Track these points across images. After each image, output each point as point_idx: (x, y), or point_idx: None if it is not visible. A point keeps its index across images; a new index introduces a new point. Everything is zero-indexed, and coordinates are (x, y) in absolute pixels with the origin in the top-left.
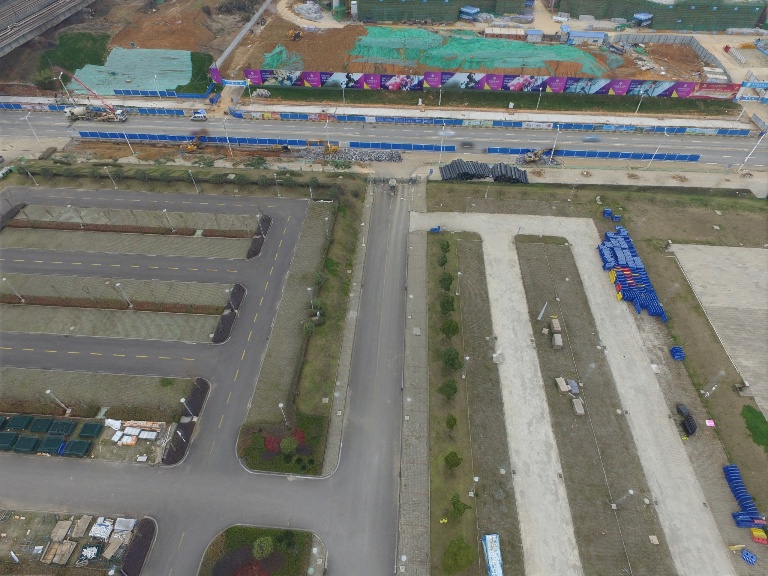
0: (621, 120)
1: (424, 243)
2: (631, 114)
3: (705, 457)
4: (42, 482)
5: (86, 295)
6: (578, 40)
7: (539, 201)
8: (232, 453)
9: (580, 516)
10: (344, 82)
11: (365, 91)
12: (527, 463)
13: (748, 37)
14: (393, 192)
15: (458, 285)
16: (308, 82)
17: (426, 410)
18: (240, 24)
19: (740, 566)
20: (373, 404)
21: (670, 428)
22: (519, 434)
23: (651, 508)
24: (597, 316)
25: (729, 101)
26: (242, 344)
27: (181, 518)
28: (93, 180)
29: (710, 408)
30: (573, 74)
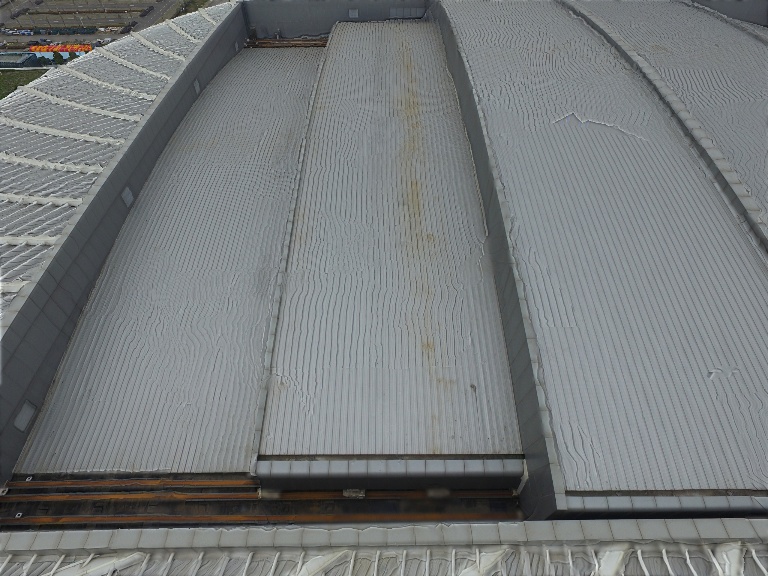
0: None
1: None
2: None
3: None
4: None
5: None
6: None
7: None
8: None
9: None
10: None
11: None
12: None
13: None
14: None
15: None
16: None
17: None
18: None
19: None
20: None
21: None
22: None
23: None
24: None
25: None
26: None
27: None
28: None
29: None
30: None
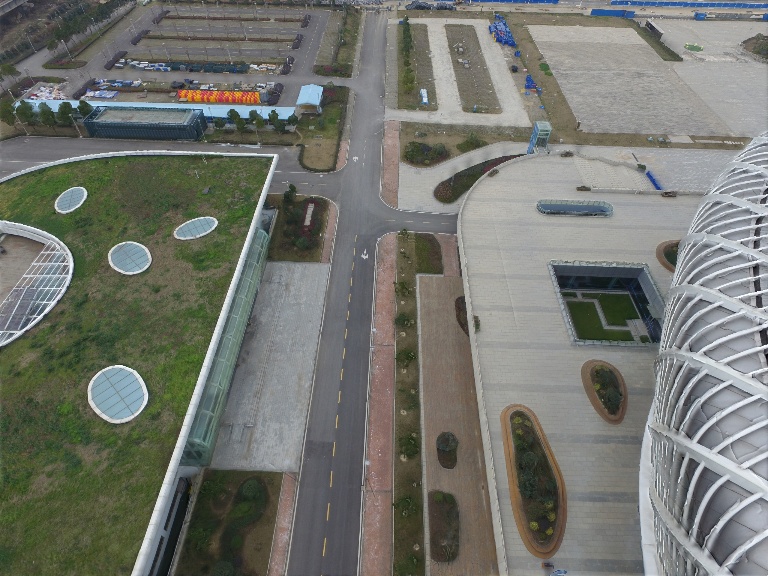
0: None
1: (396, 27)
2: None
3: None
4: (229, 78)
5: None
6: None
7: (461, 14)
8: None
9: (461, 87)
10: None
11: None
12: (441, 78)
13: None
14: (378, 12)
15: (413, 38)
16: None
17: (396, 65)
18: None
19: (523, 95)
20: (372, 64)
21: (507, 71)
22: (438, 72)
23: (492, 86)
24: (482, 46)
25: None
26: (306, 50)
27: (293, 84)
28: None
29: (527, 66)
30: None
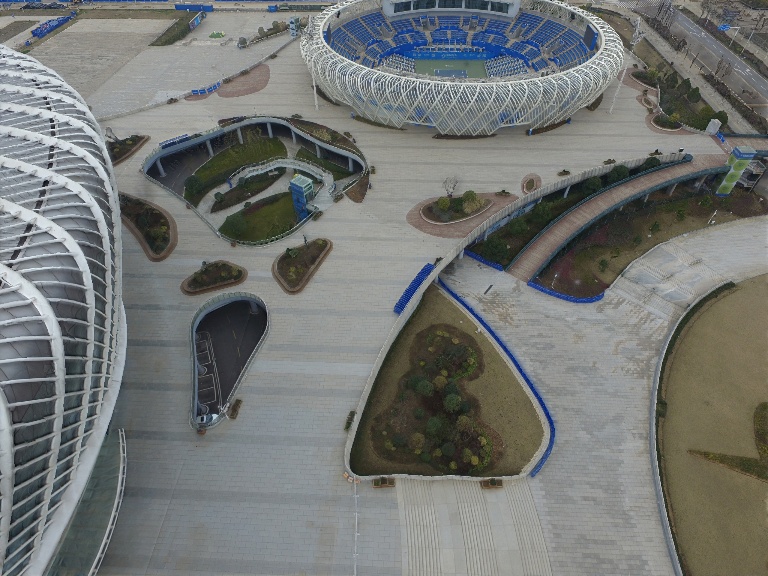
0: None
1: None
2: None
3: None
4: None
5: None
6: None
7: None
8: None
9: None
10: None
11: None
12: None
13: None
14: None
15: None
16: None
17: None
18: None
19: None
20: None
21: None
22: None
23: None
24: None
25: None
26: None
27: None
28: None
29: None
30: None
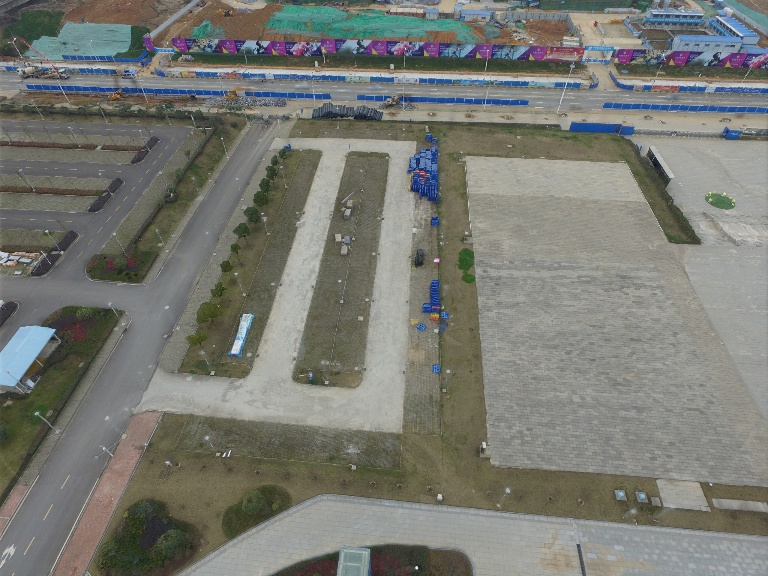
0: (481, 78)
1: None
2: (491, 73)
3: (422, 278)
4: None
5: (3, 185)
6: (469, 17)
7: (380, 130)
8: (82, 271)
9: (316, 307)
10: (255, 49)
11: (274, 57)
12: (292, 280)
13: (621, 15)
14: (266, 125)
15: (290, 182)
16: (226, 49)
17: None
18: (182, 6)
19: (413, 331)
20: (194, 247)
21: (406, 263)
22: (294, 265)
23: (368, 303)
24: (387, 201)
25: (577, 63)
26: (110, 213)
27: (36, 302)
28: (26, 114)
29: (441, 252)
30: (449, 42)
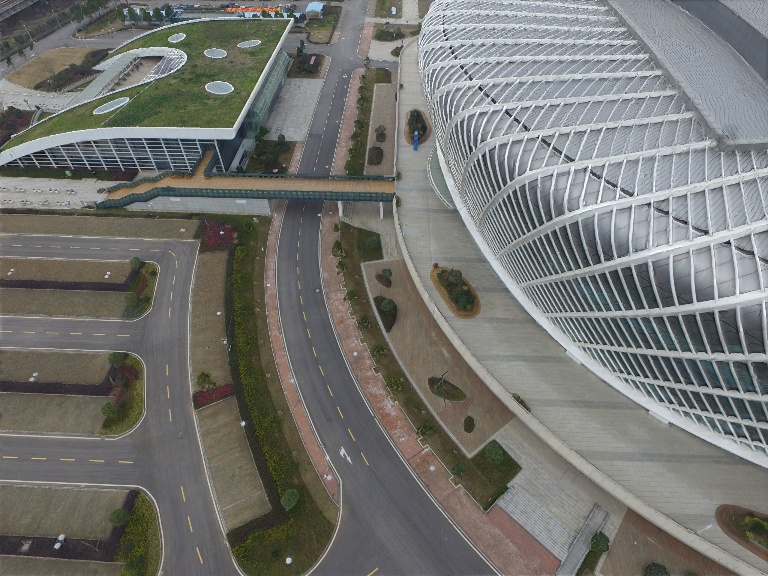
0: None
1: None
2: None
3: None
4: (259, 3)
5: None
6: None
7: None
8: None
9: None
10: None
11: None
12: (407, 2)
13: None
14: None
15: None
16: None
17: None
18: None
19: None
20: None
21: None
22: None
23: None
24: None
25: None
26: None
27: None
28: None
29: None
30: None
